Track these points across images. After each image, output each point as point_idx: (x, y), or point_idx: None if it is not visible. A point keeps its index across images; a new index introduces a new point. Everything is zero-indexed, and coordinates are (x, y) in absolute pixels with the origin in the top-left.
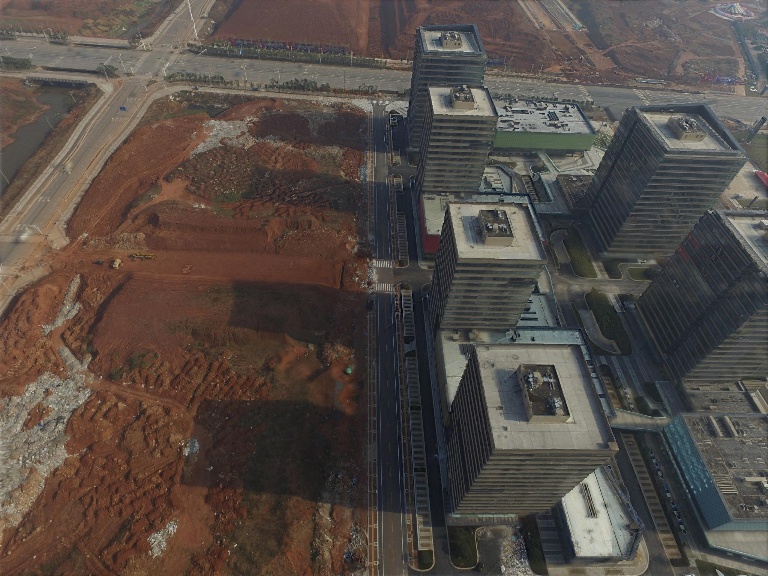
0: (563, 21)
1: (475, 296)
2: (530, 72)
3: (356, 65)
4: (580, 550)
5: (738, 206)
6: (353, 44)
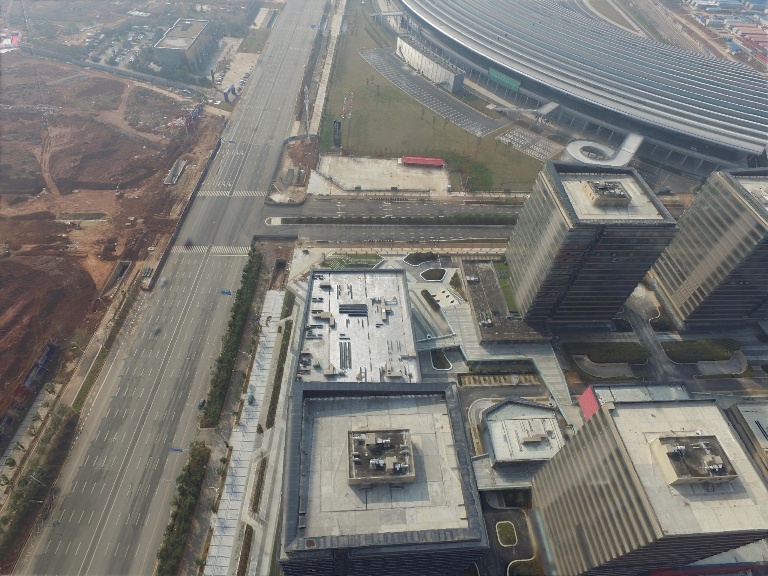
0: None
1: None
2: (104, 308)
3: None
4: None
5: (463, 194)
6: None
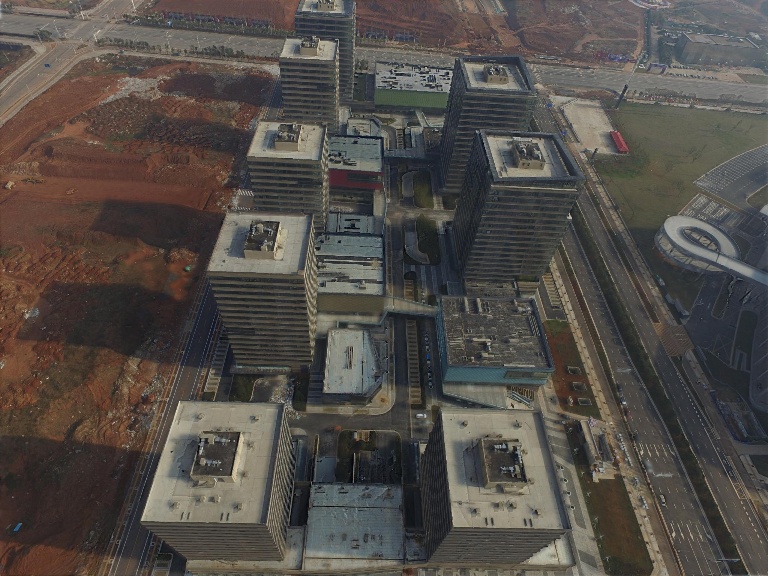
0: (487, 6)
1: (276, 196)
2: (437, 47)
3: (276, 37)
4: (329, 389)
5: (584, 158)
6: (278, 19)
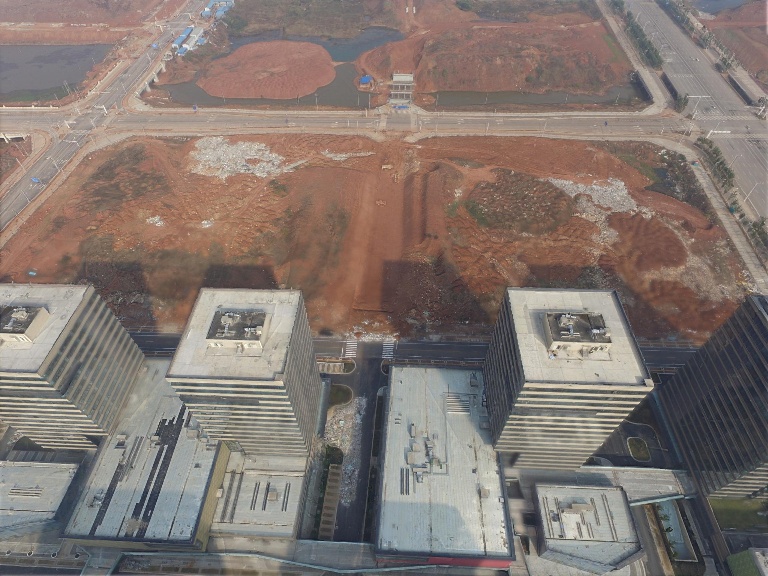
0: None
1: None
2: None
3: None
4: None
5: None
6: None
